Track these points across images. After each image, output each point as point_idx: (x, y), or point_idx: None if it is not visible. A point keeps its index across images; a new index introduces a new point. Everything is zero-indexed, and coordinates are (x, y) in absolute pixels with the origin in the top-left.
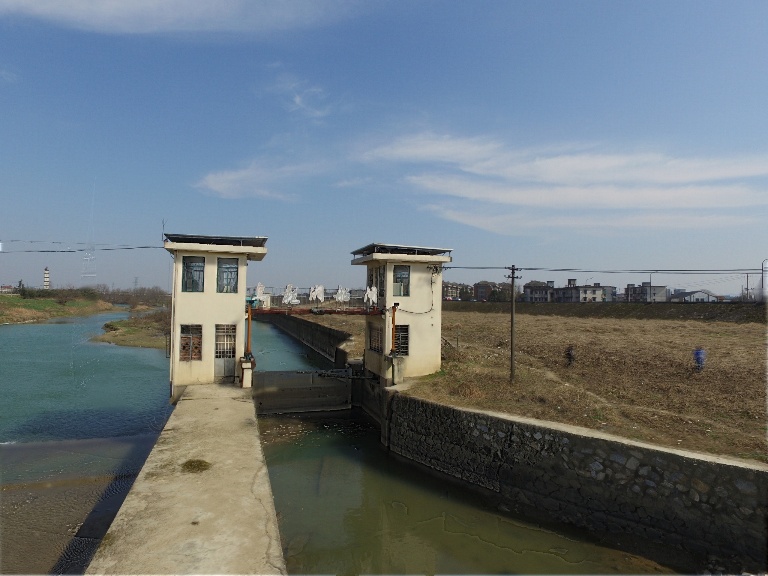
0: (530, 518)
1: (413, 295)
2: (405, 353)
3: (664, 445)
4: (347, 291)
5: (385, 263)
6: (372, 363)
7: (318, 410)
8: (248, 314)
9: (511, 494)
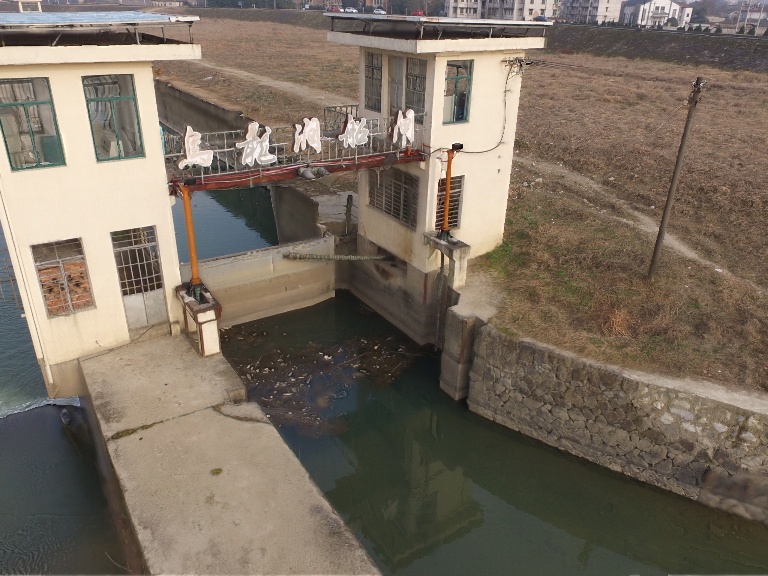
0: (761, 548)
1: (474, 119)
2: (453, 224)
3: None
4: (363, 124)
5: (430, 57)
6: (383, 234)
7: (287, 311)
8: None
9: (720, 506)
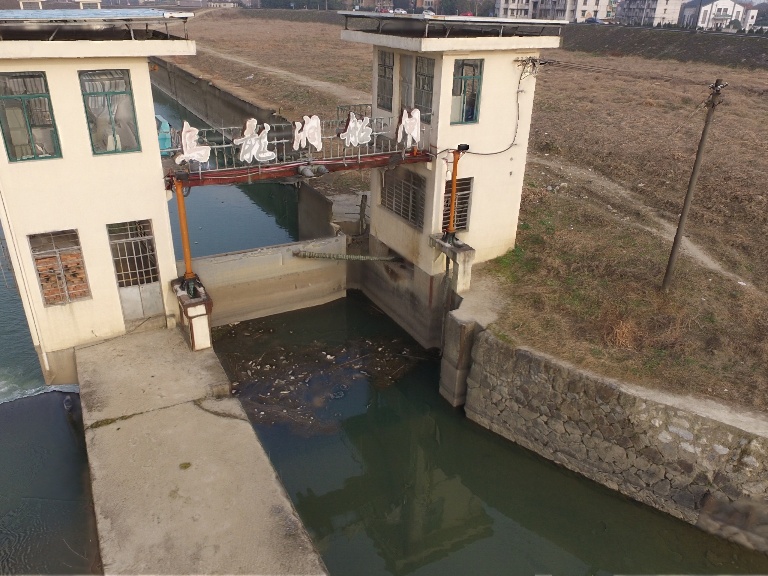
0: None
1: (485, 120)
2: (462, 226)
3: None
4: (366, 123)
5: (437, 55)
6: (392, 235)
7: (296, 309)
8: None
9: (720, 533)
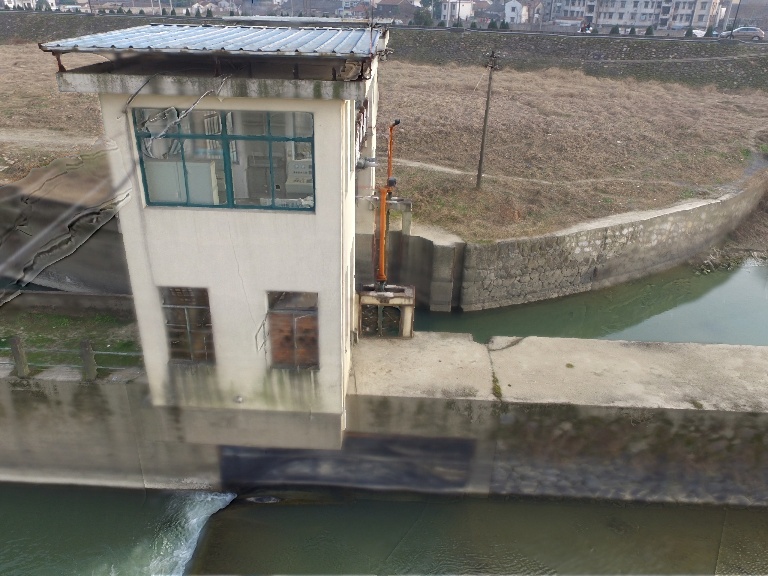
0: None
1: None
2: None
3: (666, 206)
4: None
5: None
6: None
7: None
8: None
9: (600, 286)
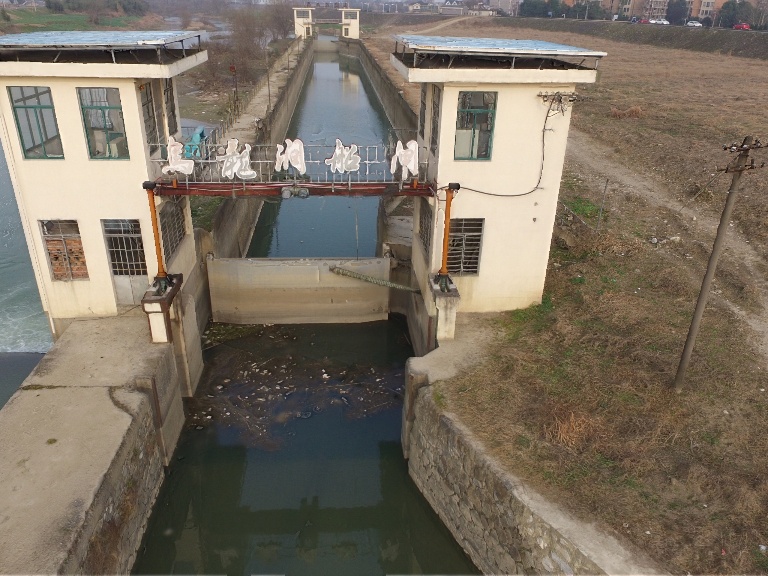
0: None
1: (499, 158)
2: (473, 269)
3: None
4: (354, 151)
5: (441, 86)
6: (418, 266)
7: (331, 322)
8: None
9: None
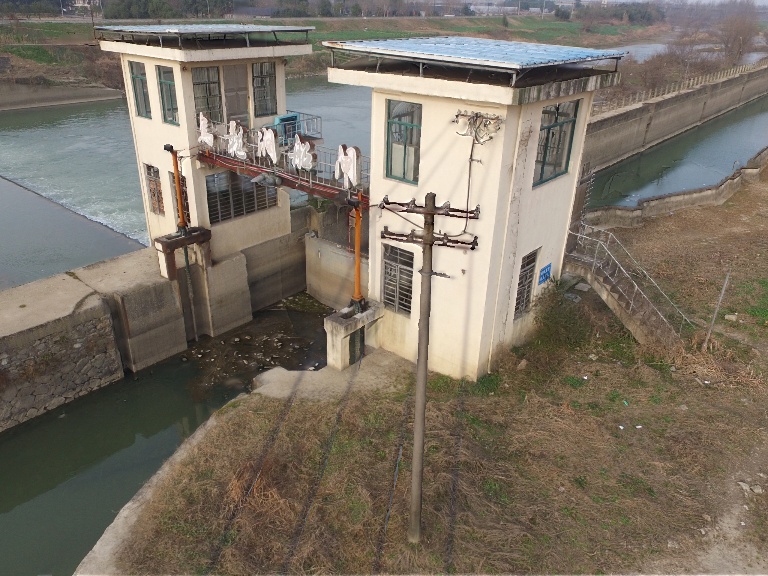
0: None
1: (426, 184)
2: (409, 309)
3: None
4: (308, 149)
5: None
6: None
7: None
8: (174, 166)
9: None
